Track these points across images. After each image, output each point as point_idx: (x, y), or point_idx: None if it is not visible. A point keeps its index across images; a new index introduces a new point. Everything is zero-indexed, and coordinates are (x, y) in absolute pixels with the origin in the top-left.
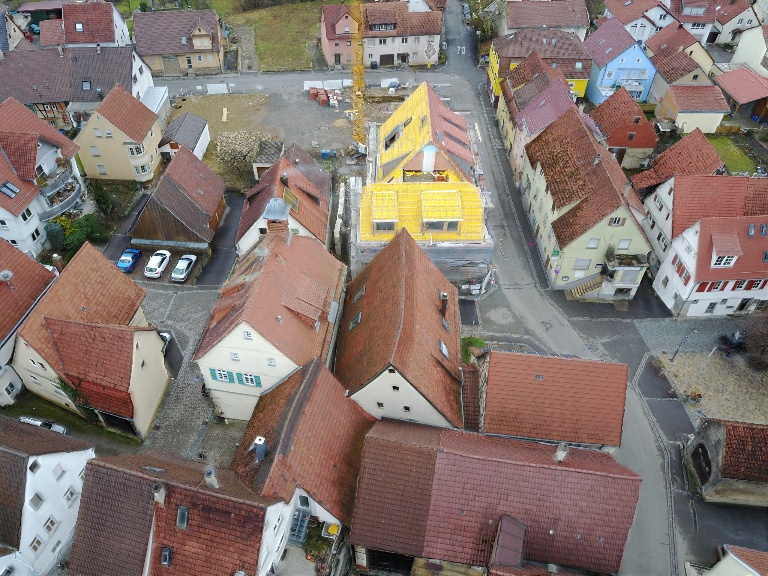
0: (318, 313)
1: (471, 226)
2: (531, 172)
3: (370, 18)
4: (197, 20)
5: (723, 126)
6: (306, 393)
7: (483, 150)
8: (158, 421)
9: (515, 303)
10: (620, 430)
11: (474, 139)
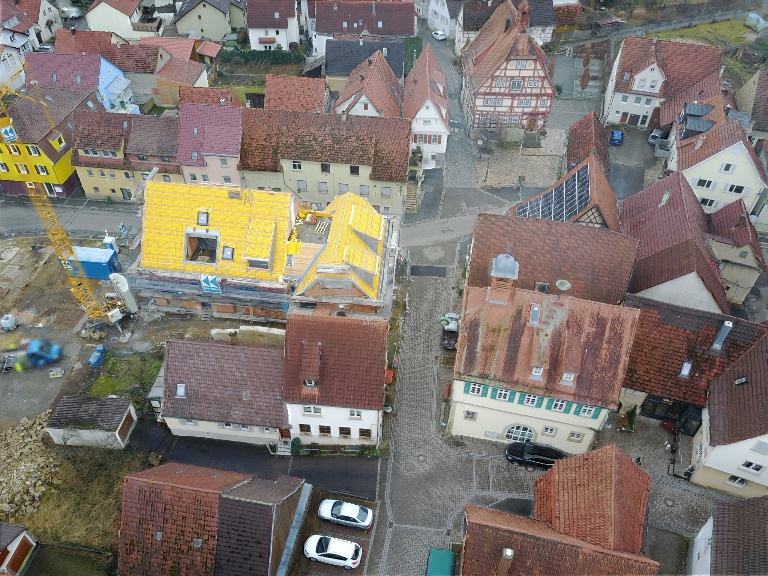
0: None
1: None
2: (271, 180)
3: None
4: None
5: (209, 79)
6: None
7: None
8: None
9: (418, 242)
10: None
11: None
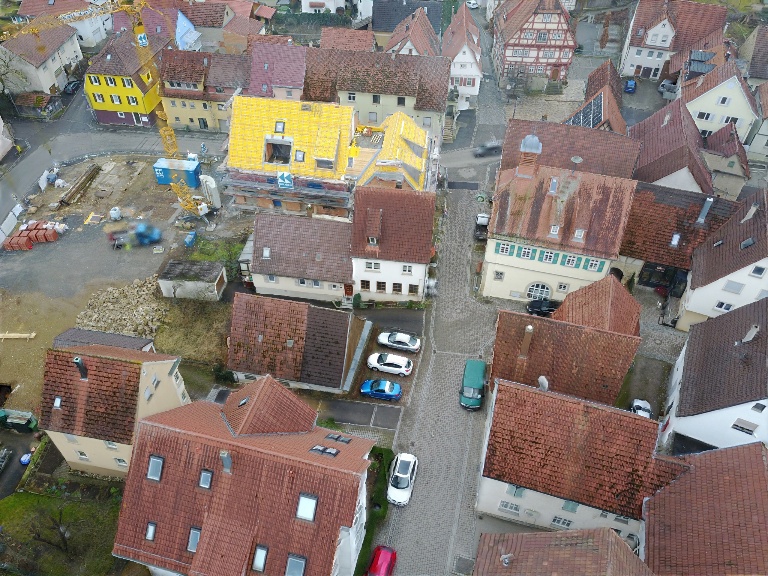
0: None
1: None
2: None
3: None
4: None
5: None
6: None
7: None
8: None
9: (454, 165)
10: None
11: None
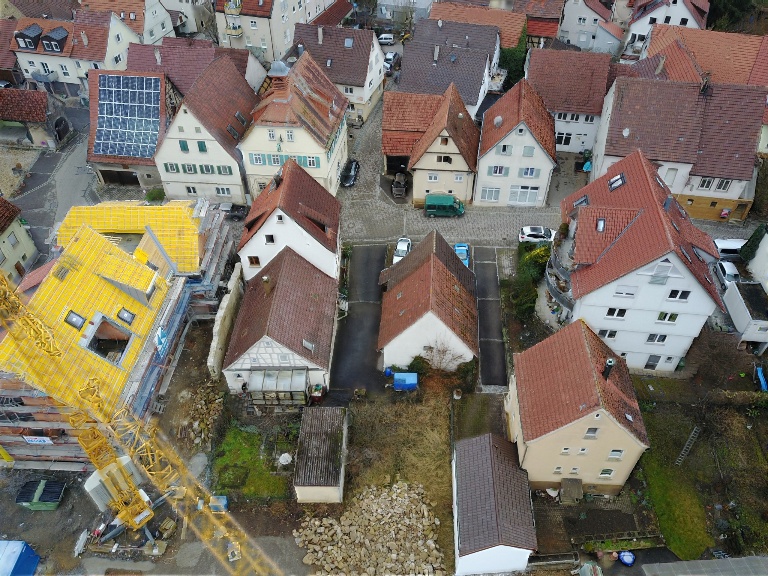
0: None
1: None
2: None
3: None
4: None
5: None
6: None
7: None
8: None
9: None
10: None
11: None
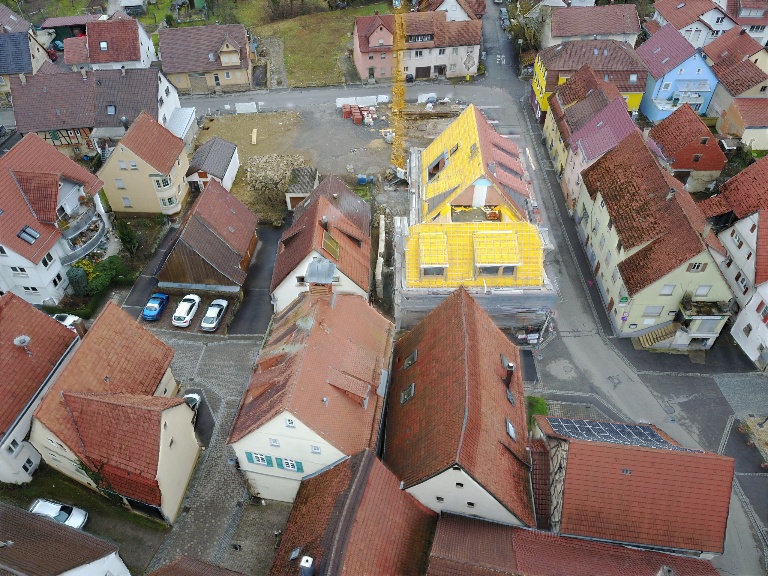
0: (367, 389)
1: (528, 270)
2: (589, 202)
3: (406, 29)
4: (225, 35)
5: None
6: (358, 495)
7: (531, 172)
8: (188, 501)
9: (577, 354)
10: (723, 534)
11: (525, 165)
